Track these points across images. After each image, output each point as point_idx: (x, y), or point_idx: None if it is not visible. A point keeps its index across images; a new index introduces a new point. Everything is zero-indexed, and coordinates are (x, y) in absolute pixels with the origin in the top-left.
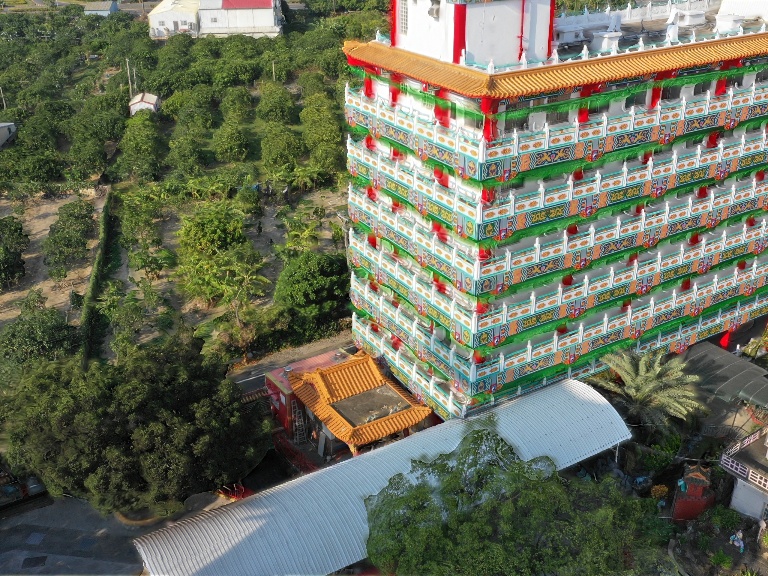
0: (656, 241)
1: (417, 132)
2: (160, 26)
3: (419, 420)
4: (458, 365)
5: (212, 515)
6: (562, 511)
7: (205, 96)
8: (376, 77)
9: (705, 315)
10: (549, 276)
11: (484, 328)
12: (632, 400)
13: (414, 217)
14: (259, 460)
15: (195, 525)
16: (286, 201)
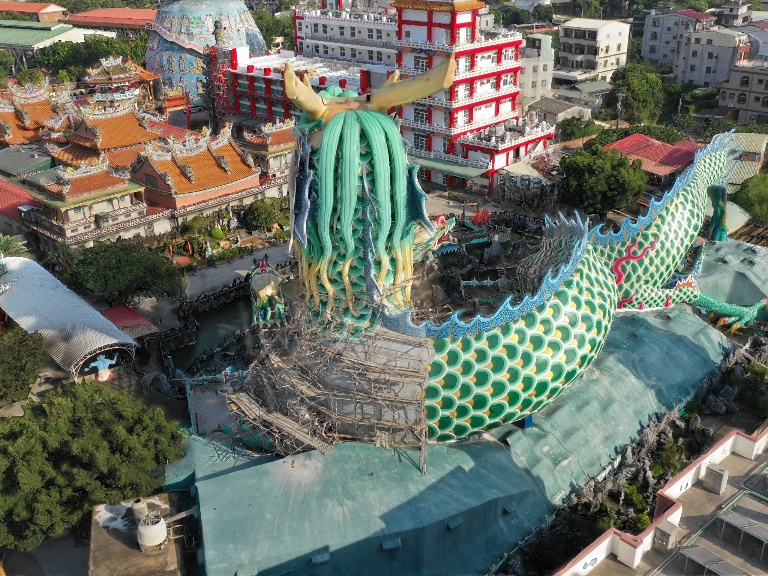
0: None
1: None
2: None
3: None
4: None
5: (64, 342)
6: None
7: None
8: None
9: None
10: None
11: None
12: None
13: None
14: None
15: (72, 343)
16: None
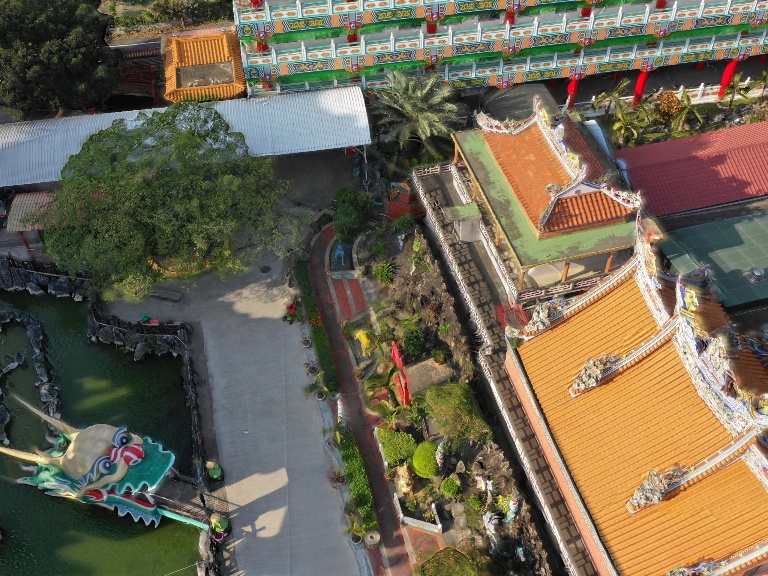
0: None
1: None
2: None
3: (234, 94)
4: None
5: (25, 122)
6: (213, 171)
7: None
8: None
9: (537, 57)
10: None
11: (247, 21)
12: (407, 116)
13: None
14: (94, 96)
15: (8, 126)
16: None
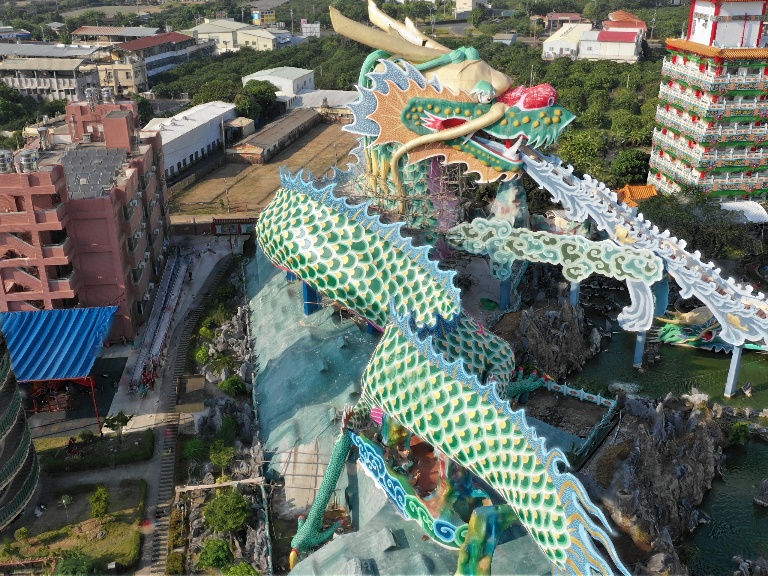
0: None
1: (690, 75)
2: (550, 51)
3: None
4: (692, 179)
5: None
6: (717, 213)
7: (578, 93)
8: (678, 54)
9: None
10: (741, 143)
11: (705, 160)
12: None
13: (685, 117)
14: None
15: None
16: (623, 148)
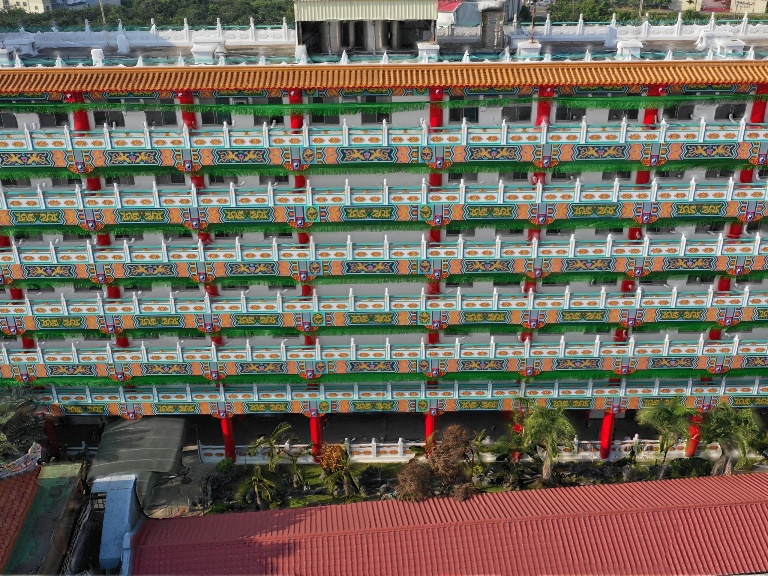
0: (10, 280)
1: None
2: None
3: None
4: None
5: None
6: None
7: None
8: None
9: (167, 387)
10: None
11: None
12: None
13: None
14: None
15: None
16: None
